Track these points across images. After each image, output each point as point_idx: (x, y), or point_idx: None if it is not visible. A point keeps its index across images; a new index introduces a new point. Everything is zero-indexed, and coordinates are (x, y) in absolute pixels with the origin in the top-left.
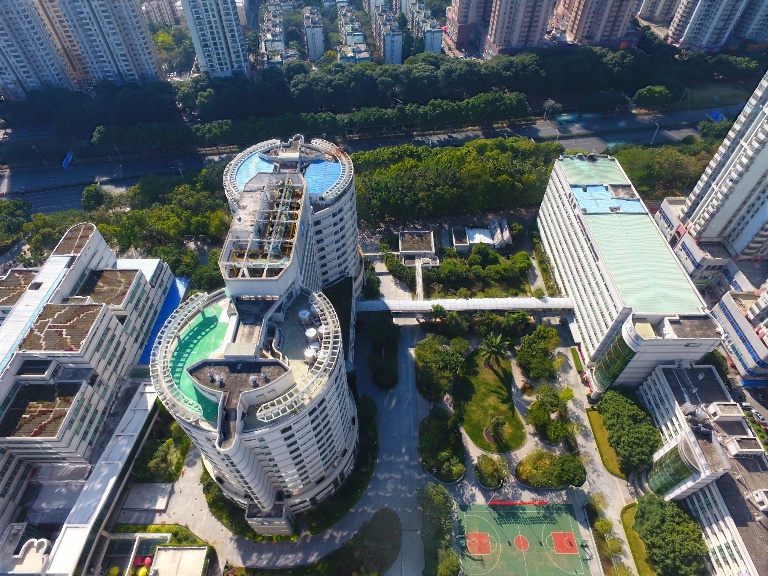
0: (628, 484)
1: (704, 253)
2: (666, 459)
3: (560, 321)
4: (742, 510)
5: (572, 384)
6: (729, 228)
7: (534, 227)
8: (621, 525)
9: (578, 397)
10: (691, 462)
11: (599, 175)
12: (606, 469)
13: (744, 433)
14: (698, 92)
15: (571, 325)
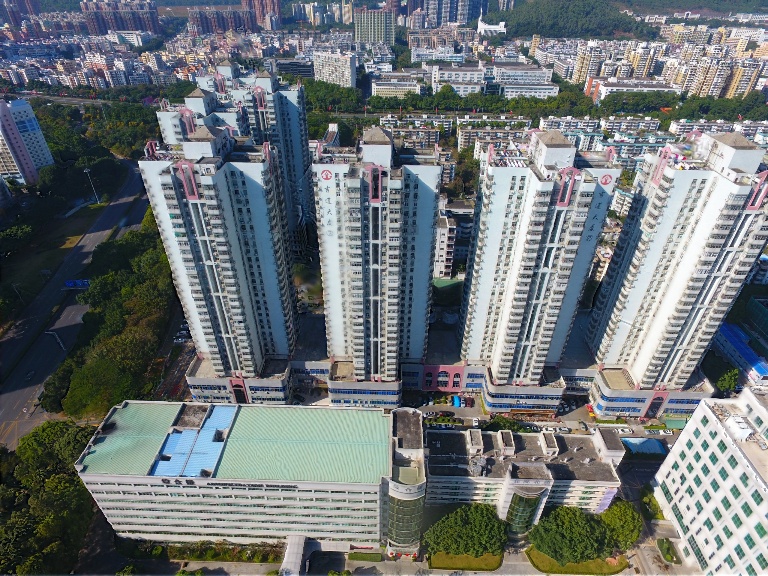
0: (508, 552)
1: (274, 377)
2: (517, 510)
3: (306, 560)
4: (561, 469)
5: (397, 574)
6: (262, 347)
7: (132, 546)
8: (551, 575)
9: (414, 573)
10: (540, 492)
11: (147, 431)
12: (497, 570)
13: (490, 437)
14: (15, 278)
15: (324, 548)
